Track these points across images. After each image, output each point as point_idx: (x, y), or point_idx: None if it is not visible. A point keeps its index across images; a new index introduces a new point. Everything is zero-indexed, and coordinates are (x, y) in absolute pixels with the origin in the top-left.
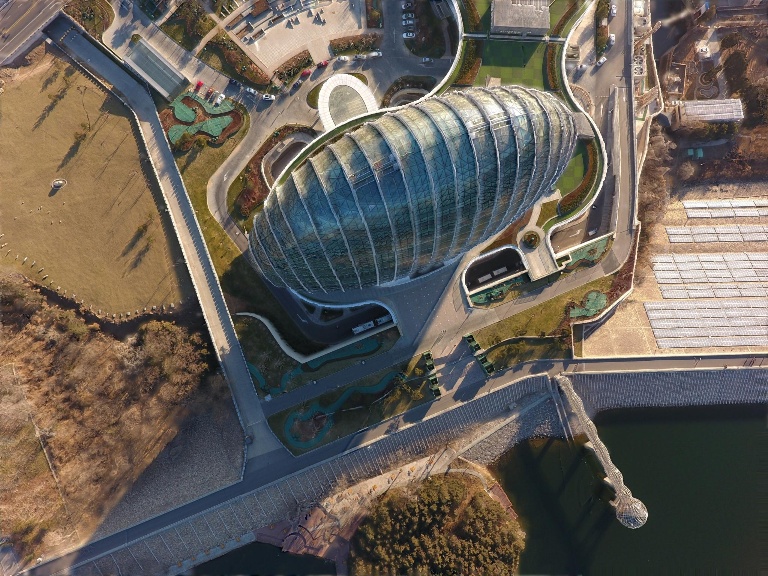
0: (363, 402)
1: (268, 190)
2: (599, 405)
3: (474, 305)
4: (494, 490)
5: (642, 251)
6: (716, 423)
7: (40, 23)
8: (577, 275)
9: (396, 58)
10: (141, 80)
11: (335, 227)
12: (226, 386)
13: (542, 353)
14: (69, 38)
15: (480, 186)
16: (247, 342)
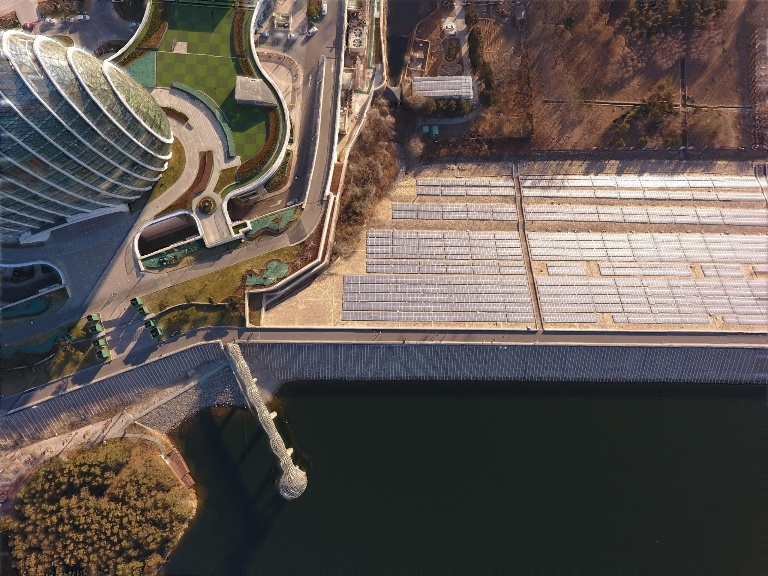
0: (27, 362)
1: None
2: (283, 376)
3: (146, 269)
4: (172, 457)
5: (348, 224)
6: (403, 399)
7: None
8: (260, 244)
9: (104, 22)
10: None
11: None
12: None
13: (216, 320)
14: None
15: None
16: None
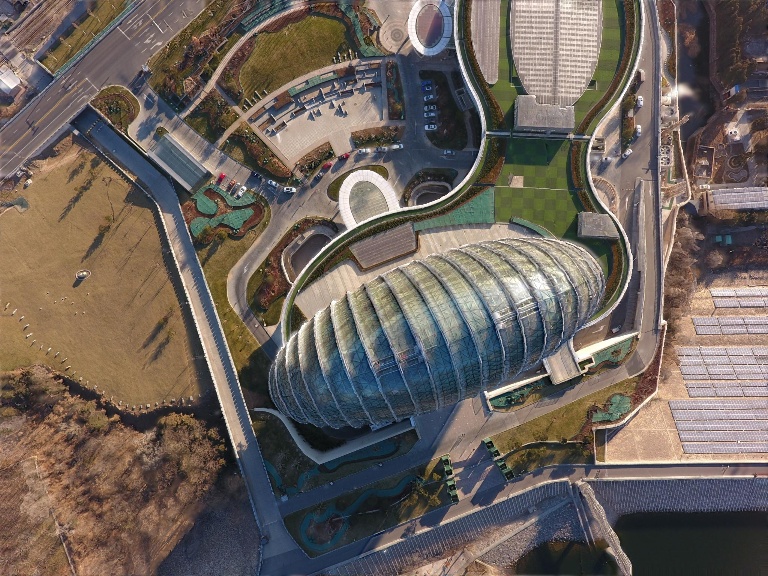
0: (380, 506)
1: (287, 283)
2: (622, 509)
3: (494, 408)
4: None
5: (667, 347)
6: (744, 531)
7: (68, 116)
8: (600, 377)
9: (417, 150)
10: (164, 172)
11: (357, 404)
12: (243, 485)
13: (563, 458)
14: (95, 129)
15: (506, 365)
16: (264, 439)
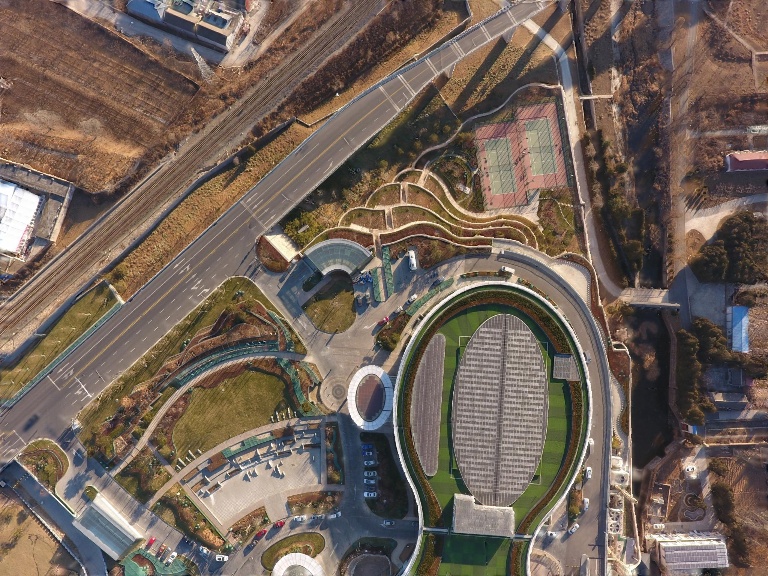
0: None
1: None
2: None
3: None
4: None
5: None
6: None
7: None
8: None
9: (356, 517)
10: None
11: None
12: None
13: None
14: None
15: None
16: None
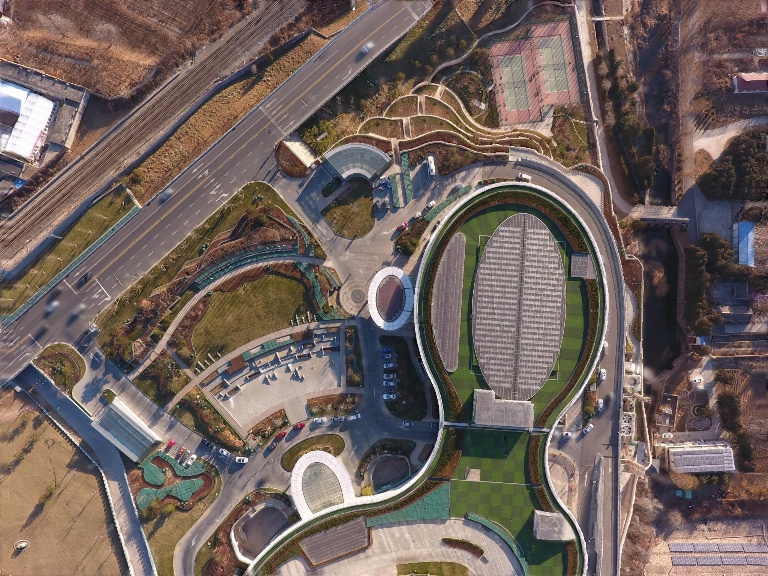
0: None
1: (237, 560)
2: None
3: None
4: None
5: None
6: None
7: (9, 375)
8: None
9: (375, 419)
10: None
11: None
12: None
13: None
14: None
15: None
16: None
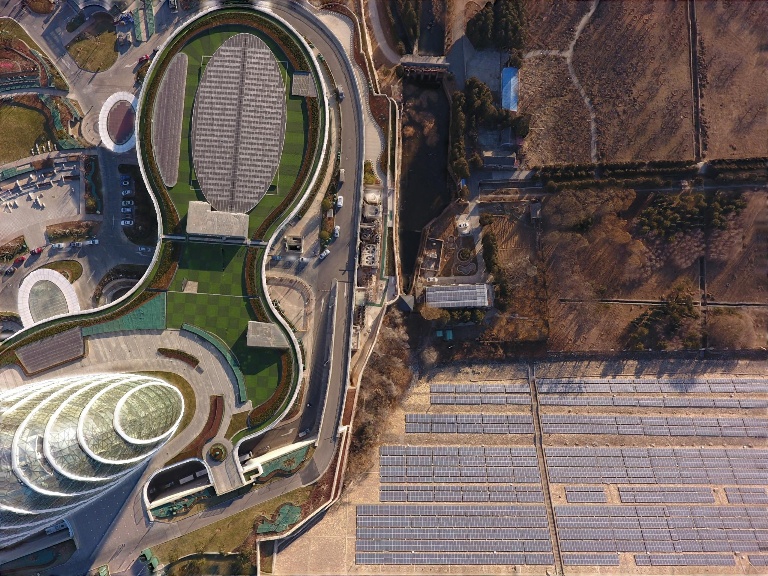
0: None
1: None
2: None
3: (155, 519)
4: None
5: (361, 450)
6: None
7: None
8: (271, 486)
9: (113, 245)
10: None
11: None
12: None
13: (227, 569)
14: None
15: None
16: None
